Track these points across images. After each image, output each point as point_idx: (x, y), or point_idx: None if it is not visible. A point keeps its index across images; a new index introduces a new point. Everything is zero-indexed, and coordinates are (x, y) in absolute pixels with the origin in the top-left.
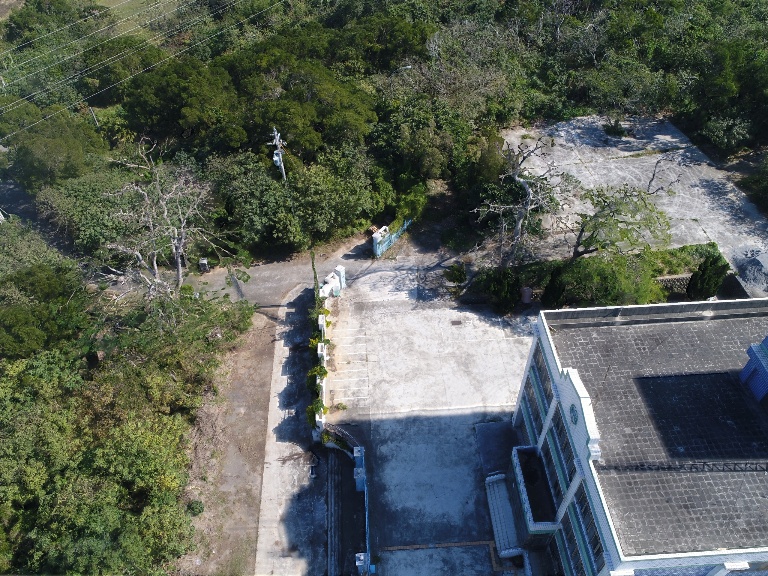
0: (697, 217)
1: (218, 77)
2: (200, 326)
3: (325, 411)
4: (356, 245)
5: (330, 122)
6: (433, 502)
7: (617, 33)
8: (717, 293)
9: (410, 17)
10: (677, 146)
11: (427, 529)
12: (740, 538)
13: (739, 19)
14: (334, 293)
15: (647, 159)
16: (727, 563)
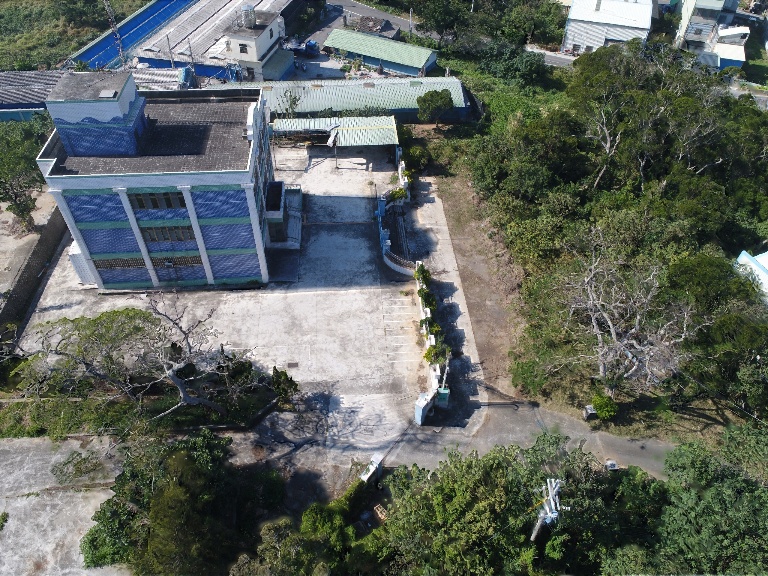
0: None
1: None
2: (567, 381)
3: None
4: None
5: None
6: (337, 241)
7: None
8: None
9: None
10: None
11: (343, 229)
12: (200, 105)
13: None
14: None
15: None
16: None
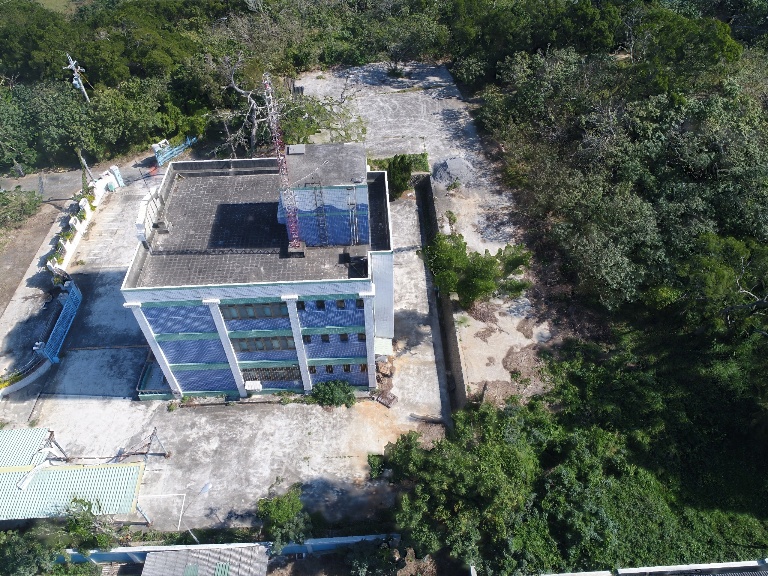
0: (425, 136)
1: (75, 29)
2: None
3: (59, 261)
4: (147, 157)
5: (147, 61)
6: (122, 322)
7: None
8: (417, 191)
9: None
10: (440, 85)
11: (109, 338)
12: None
13: None
14: (109, 188)
15: (410, 94)
16: (204, 299)
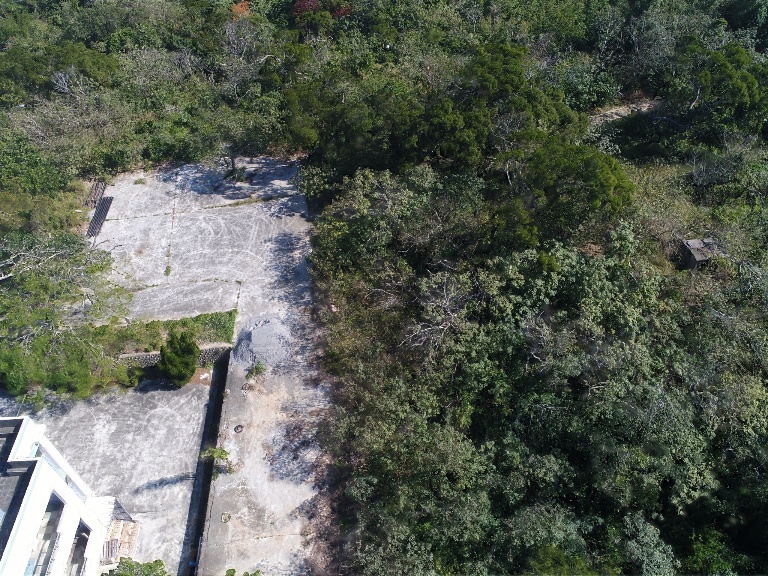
0: (243, 279)
1: None
2: None
3: None
4: None
5: None
6: None
7: (267, 67)
8: (216, 369)
9: (131, 42)
10: (285, 193)
11: None
12: None
13: (451, 47)
14: None
15: (243, 209)
16: None
